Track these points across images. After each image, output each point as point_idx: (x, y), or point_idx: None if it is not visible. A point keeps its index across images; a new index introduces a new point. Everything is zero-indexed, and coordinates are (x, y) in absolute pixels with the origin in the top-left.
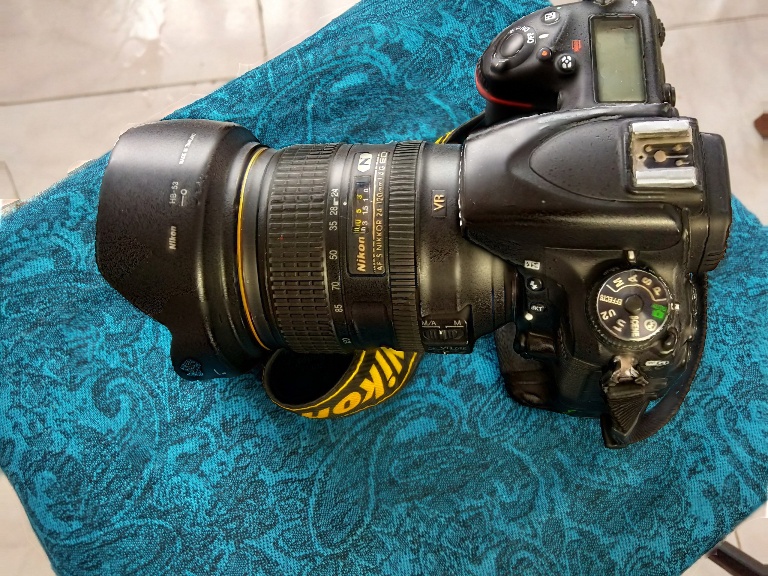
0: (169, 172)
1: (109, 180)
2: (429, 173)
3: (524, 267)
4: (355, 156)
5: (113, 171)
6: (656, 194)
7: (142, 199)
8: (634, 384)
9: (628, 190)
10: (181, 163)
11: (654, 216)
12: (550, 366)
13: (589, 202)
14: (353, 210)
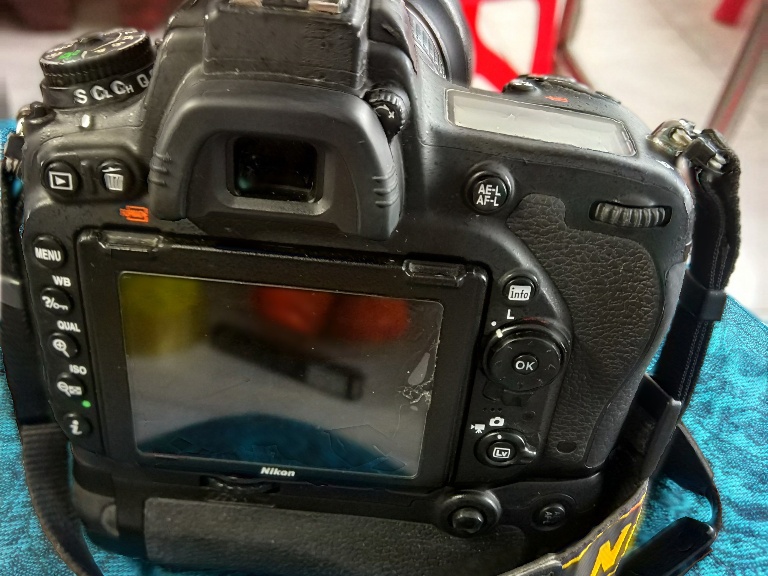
0: None
1: None
2: None
3: None
4: None
5: None
6: None
7: None
8: None
9: None
10: None
11: None
12: None
13: None
14: None
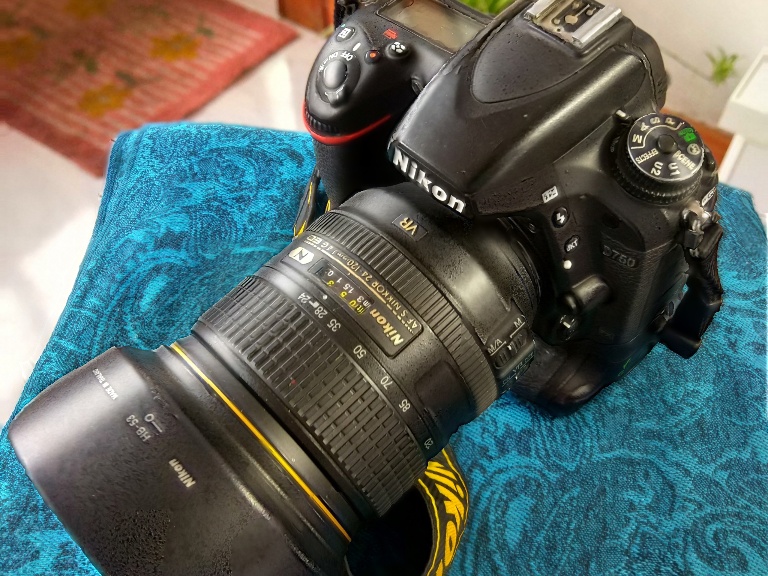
0: (110, 415)
1: (44, 480)
2: (371, 215)
3: (544, 204)
4: (284, 261)
5: (39, 468)
6: (601, 42)
7: (106, 464)
8: (710, 228)
9: (579, 56)
10: (115, 397)
11: (614, 63)
12: (587, 330)
13: (560, 88)
14: (338, 296)
